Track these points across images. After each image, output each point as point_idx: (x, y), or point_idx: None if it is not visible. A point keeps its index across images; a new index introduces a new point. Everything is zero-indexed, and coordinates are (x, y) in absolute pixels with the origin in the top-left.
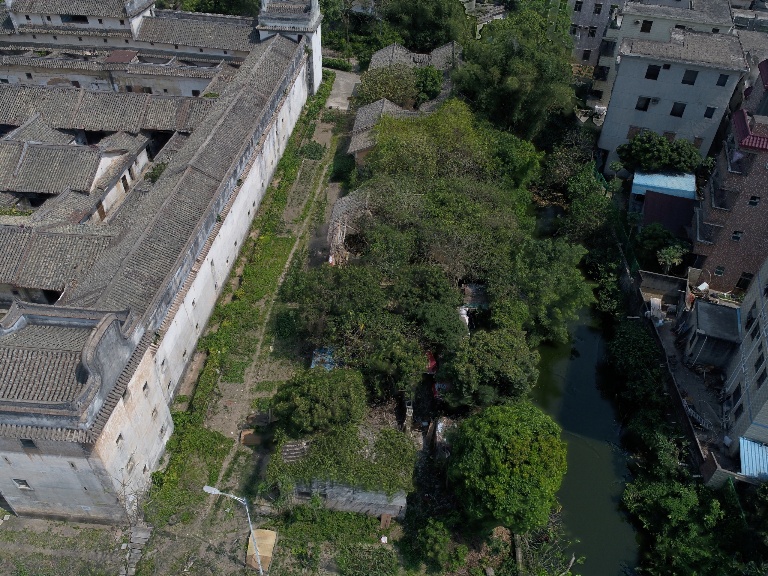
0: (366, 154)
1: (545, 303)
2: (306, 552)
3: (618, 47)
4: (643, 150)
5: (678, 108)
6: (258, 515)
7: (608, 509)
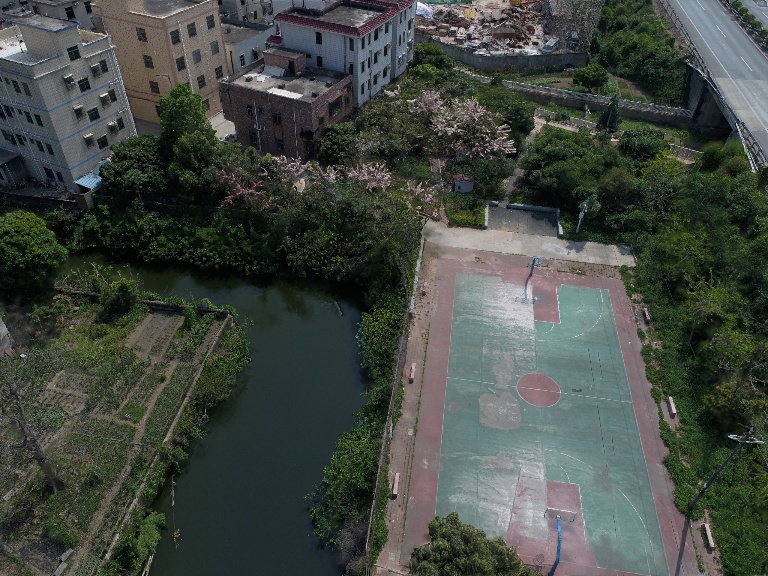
0: None
1: None
2: None
3: None
4: None
5: None
6: None
7: (75, 260)
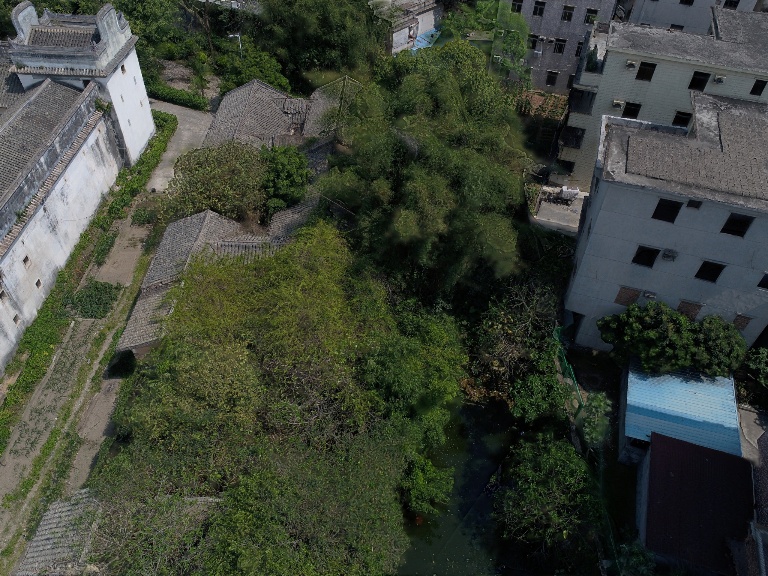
0: (150, 349)
1: None
2: None
3: (599, 100)
4: (645, 340)
5: (710, 269)
6: None
7: None
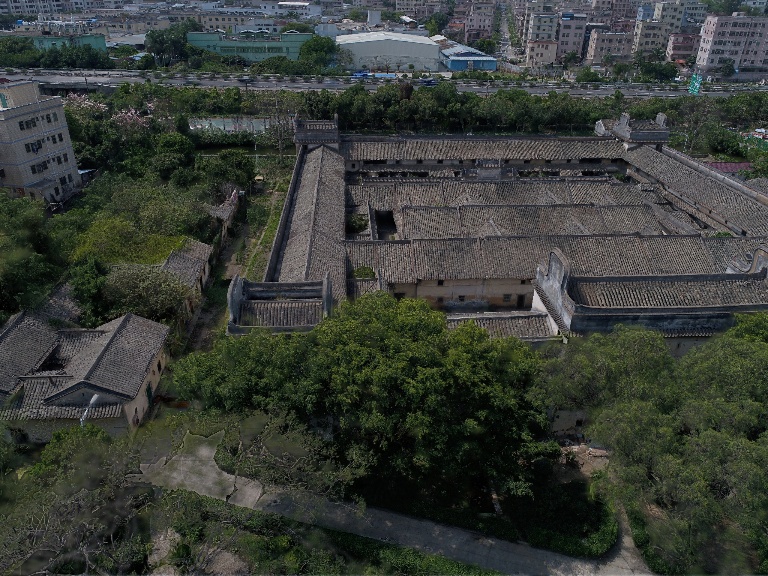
0: None
1: None
2: None
3: None
4: None
5: None
6: None
7: None
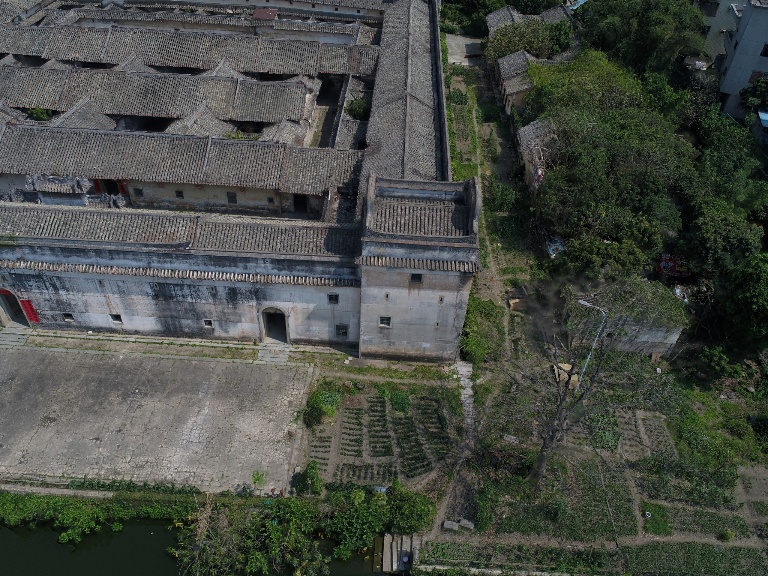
0: (523, 95)
1: (740, 200)
2: (601, 379)
3: (721, 7)
4: (767, 91)
5: None
6: (552, 355)
7: None
